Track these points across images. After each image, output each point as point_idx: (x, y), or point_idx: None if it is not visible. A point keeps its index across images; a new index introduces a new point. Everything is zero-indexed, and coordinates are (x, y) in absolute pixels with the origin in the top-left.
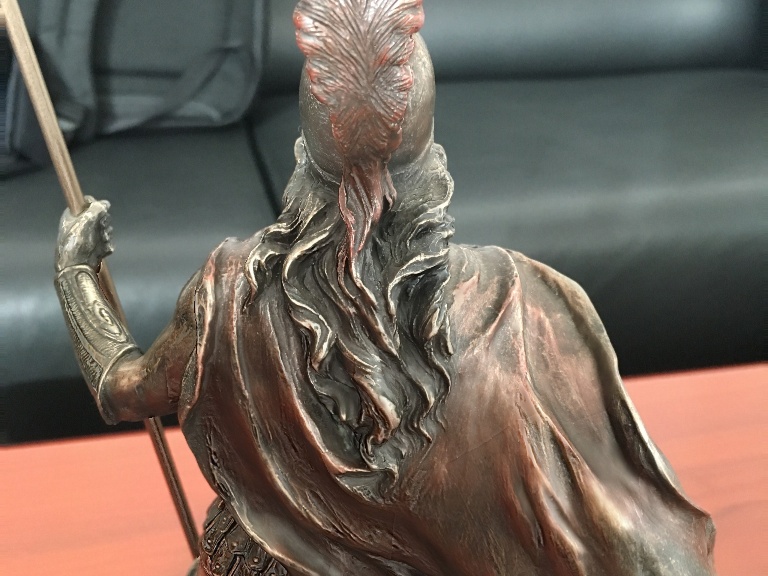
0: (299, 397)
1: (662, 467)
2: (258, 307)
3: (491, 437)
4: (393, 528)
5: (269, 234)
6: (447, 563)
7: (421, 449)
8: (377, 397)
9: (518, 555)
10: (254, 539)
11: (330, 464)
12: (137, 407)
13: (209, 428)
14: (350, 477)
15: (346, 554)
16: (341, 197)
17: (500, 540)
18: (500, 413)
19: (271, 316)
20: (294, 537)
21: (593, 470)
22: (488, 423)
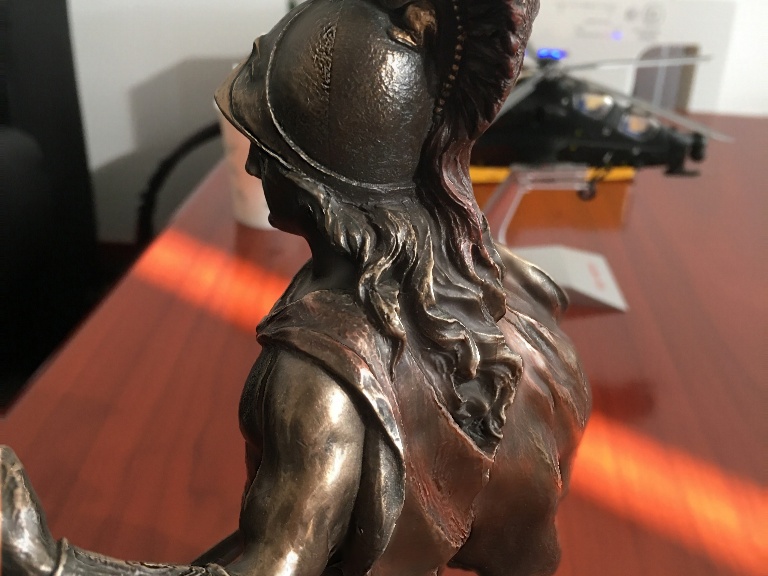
0: (455, 422)
1: None
2: (405, 360)
3: None
4: None
5: (378, 278)
6: (504, 491)
7: None
8: (519, 358)
9: None
10: None
11: (488, 462)
12: None
13: None
14: None
15: None
16: (452, 188)
17: (536, 430)
18: None
19: (415, 361)
20: None
21: None
22: None
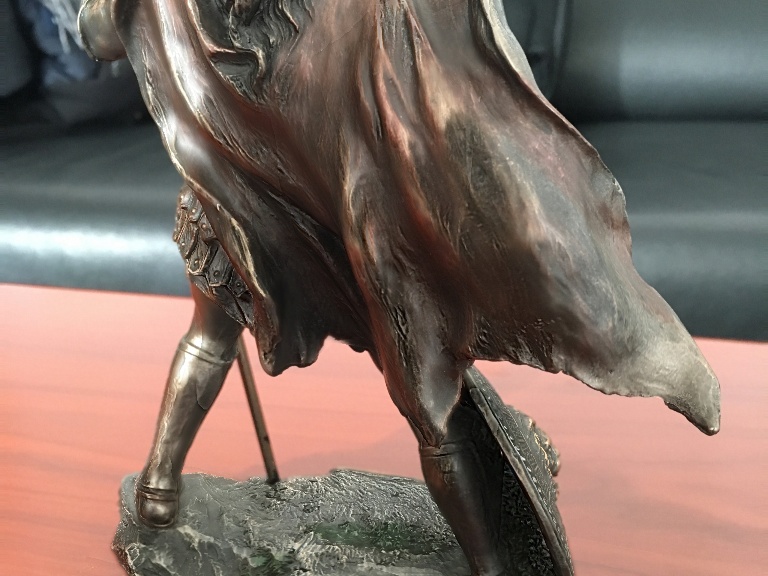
0: None
1: (501, 42)
2: None
3: (352, 26)
4: (277, 146)
5: None
6: (316, 182)
7: (289, 39)
8: None
9: (362, 153)
10: (176, 165)
11: (203, 42)
12: (104, 32)
13: (144, 41)
14: (223, 63)
15: (252, 192)
16: None
17: (348, 137)
18: (363, 0)
19: None
20: (210, 169)
21: (436, 51)
22: (352, 12)
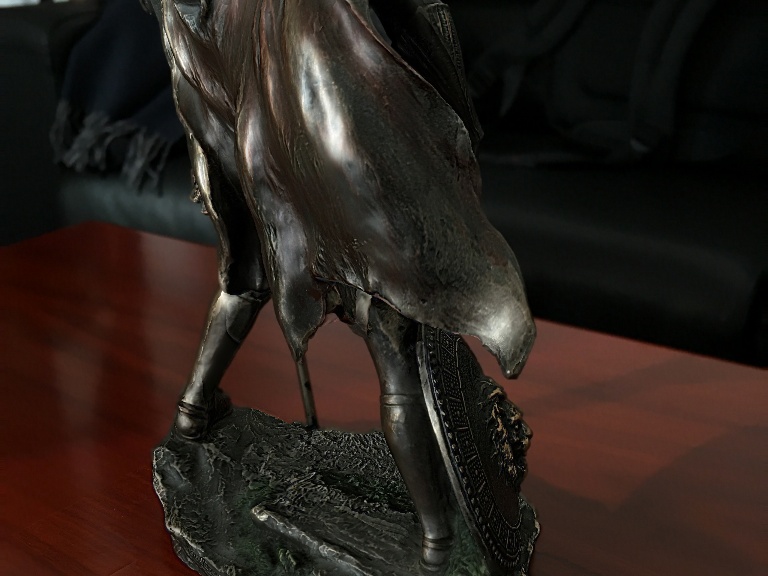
0: None
1: None
2: None
3: None
4: (224, 80)
5: None
6: None
7: None
8: None
9: (251, 81)
10: (175, 101)
11: None
12: None
13: None
14: (182, 4)
15: None
16: None
17: (246, 67)
18: None
19: None
20: (196, 104)
21: None
22: None
